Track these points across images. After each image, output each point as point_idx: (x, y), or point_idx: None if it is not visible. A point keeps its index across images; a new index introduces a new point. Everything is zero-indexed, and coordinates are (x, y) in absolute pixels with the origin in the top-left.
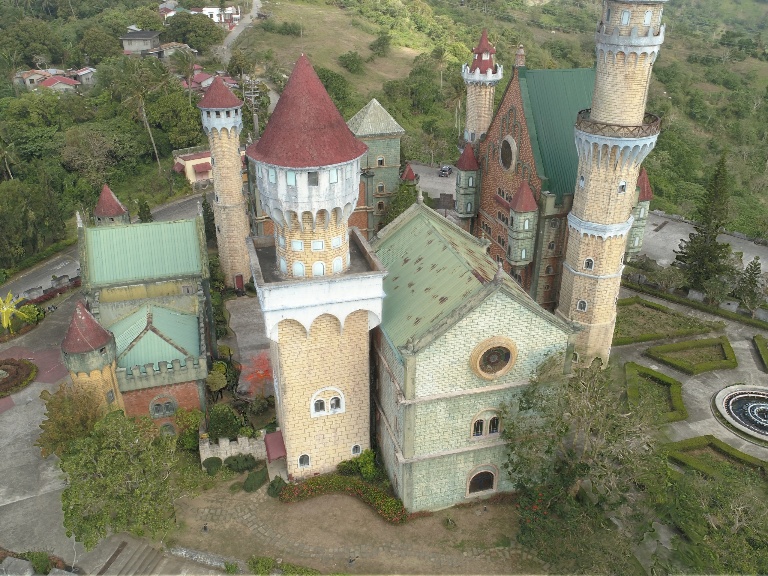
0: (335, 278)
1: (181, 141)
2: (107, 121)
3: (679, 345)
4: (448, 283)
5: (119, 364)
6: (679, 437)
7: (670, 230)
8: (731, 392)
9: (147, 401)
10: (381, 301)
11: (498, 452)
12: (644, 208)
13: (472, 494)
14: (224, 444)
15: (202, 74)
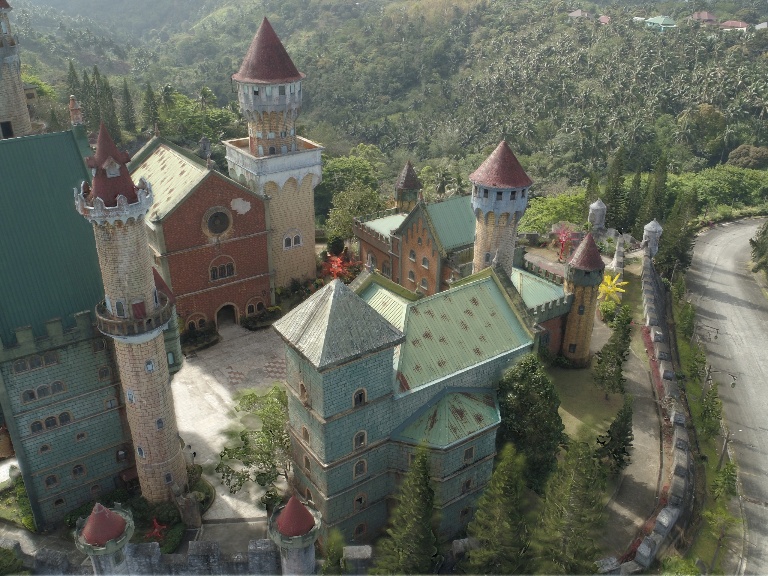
0: None
1: None
2: None
3: None
4: None
5: None
6: None
7: None
8: None
9: None
10: None
11: None
12: None
13: None
14: None
15: None
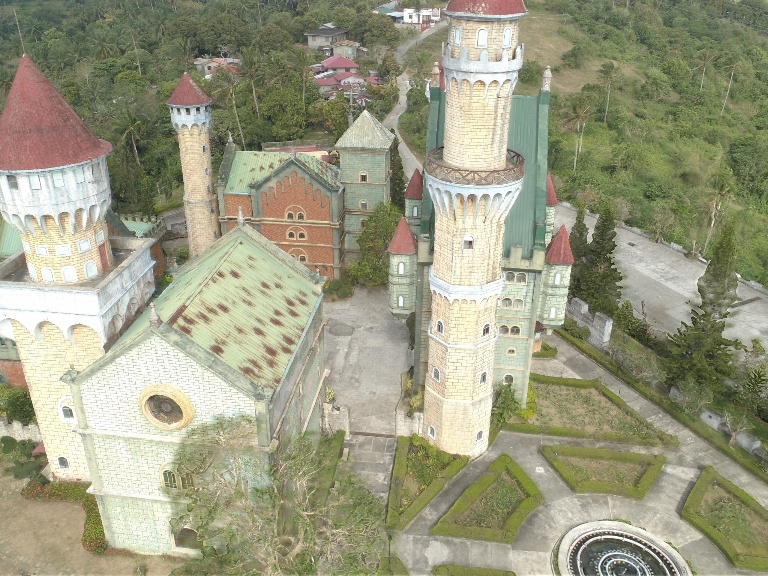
0: (44, 287)
1: (281, 135)
2: None
3: (590, 451)
4: (164, 315)
5: None
6: (482, 562)
7: (753, 309)
8: (601, 528)
9: None
10: (101, 320)
11: (200, 512)
12: (560, 273)
13: (180, 548)
14: (17, 426)
15: (346, 72)
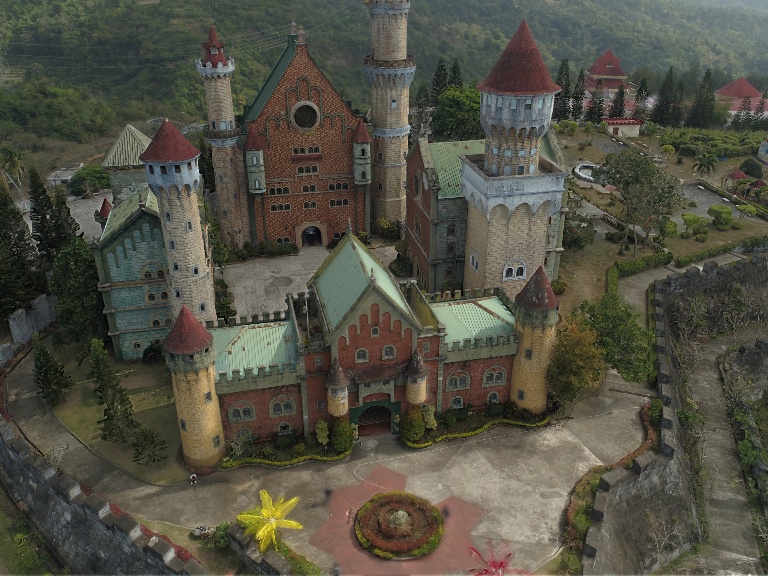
0: None
1: None
2: None
3: None
4: None
5: None
6: None
7: None
8: None
9: None
10: None
11: None
12: None
13: None
14: None
15: None
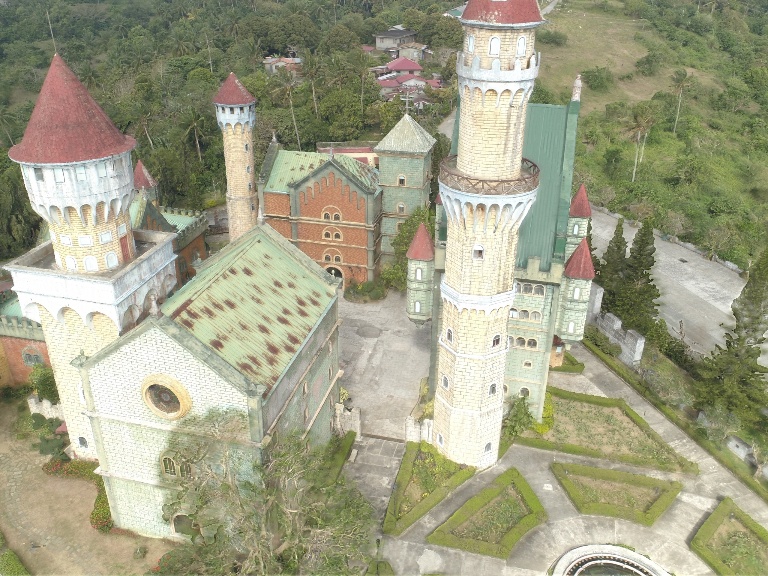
0: (65, 274)
1: (337, 135)
2: (295, 109)
3: (603, 472)
4: None
5: (3, 310)
6: (474, 575)
7: None
8: (603, 552)
9: (20, 348)
10: (116, 309)
11: (197, 500)
12: (579, 288)
13: (179, 534)
14: (46, 405)
15: (409, 75)
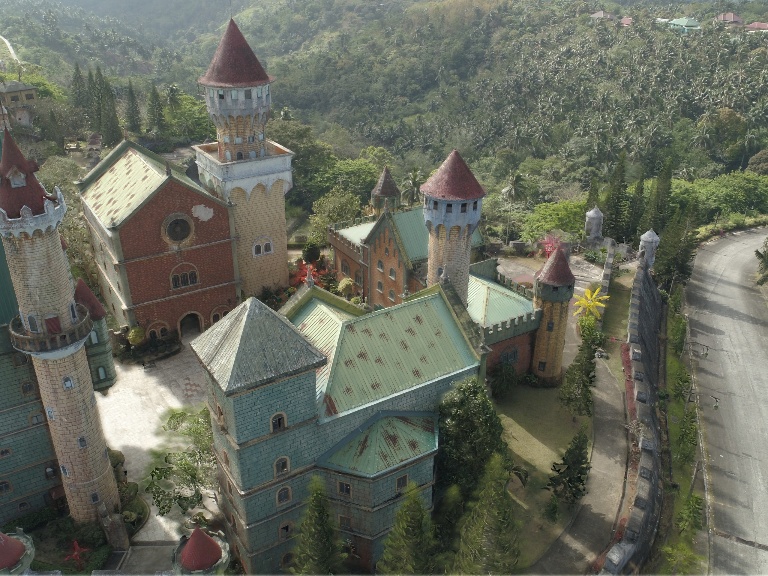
0: None
1: None
2: None
3: None
4: None
5: None
6: None
7: None
8: None
9: None
10: None
11: None
12: None
13: None
14: None
15: None
